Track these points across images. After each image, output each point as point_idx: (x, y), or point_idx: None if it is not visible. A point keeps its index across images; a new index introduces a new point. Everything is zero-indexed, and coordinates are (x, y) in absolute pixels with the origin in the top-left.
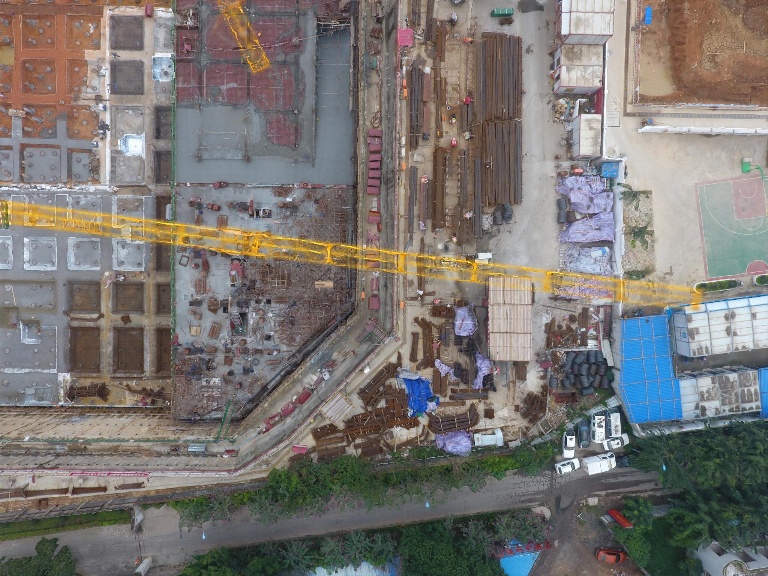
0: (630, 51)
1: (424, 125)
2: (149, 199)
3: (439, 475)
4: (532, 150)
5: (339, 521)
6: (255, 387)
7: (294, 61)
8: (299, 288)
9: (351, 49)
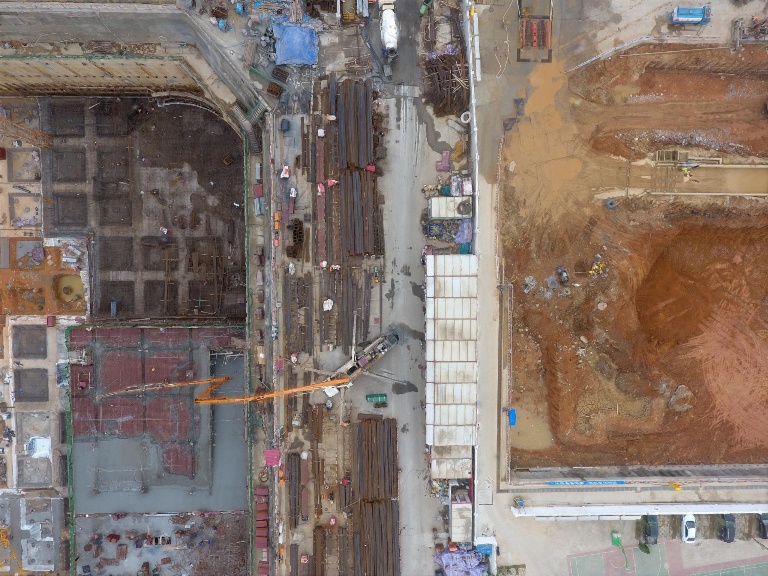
0: (502, 430)
1: (302, 508)
2: (57, 501)
3: None
4: (410, 523)
5: None
6: None
7: (189, 393)
8: None
9: None
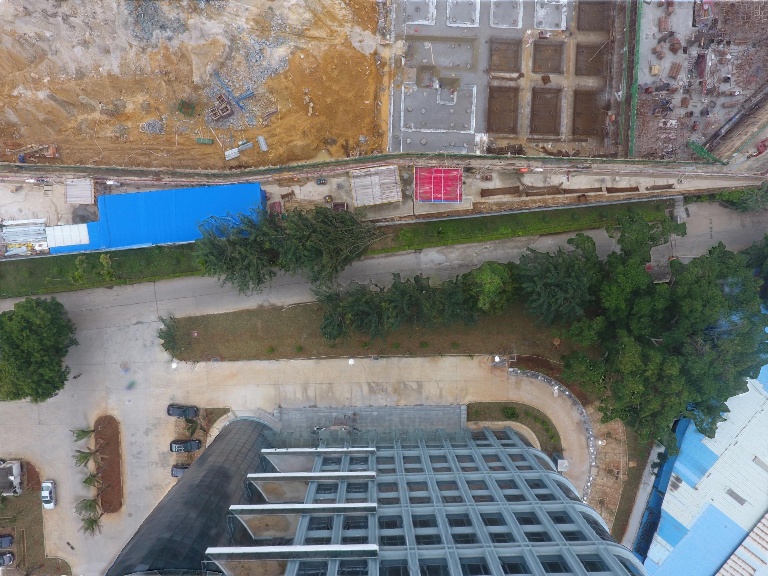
0: None
1: None
2: None
3: None
4: None
5: None
6: (709, 131)
7: None
8: (759, 30)
9: None
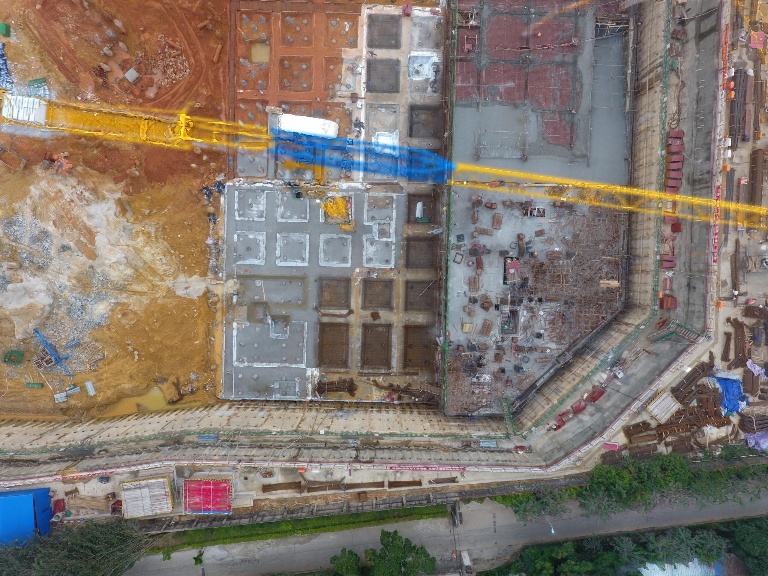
0: None
1: (746, 127)
2: (401, 197)
3: (764, 474)
4: None
5: (650, 518)
6: (524, 384)
7: (572, 61)
8: (570, 287)
9: (630, 50)
